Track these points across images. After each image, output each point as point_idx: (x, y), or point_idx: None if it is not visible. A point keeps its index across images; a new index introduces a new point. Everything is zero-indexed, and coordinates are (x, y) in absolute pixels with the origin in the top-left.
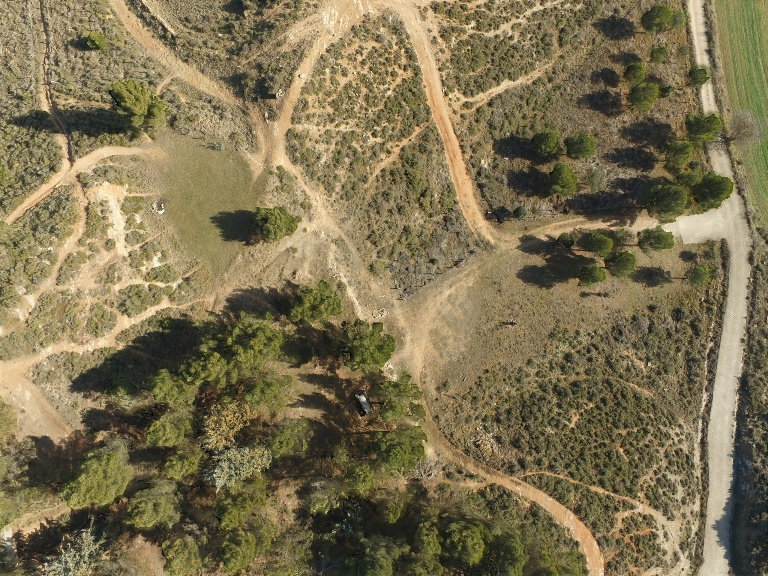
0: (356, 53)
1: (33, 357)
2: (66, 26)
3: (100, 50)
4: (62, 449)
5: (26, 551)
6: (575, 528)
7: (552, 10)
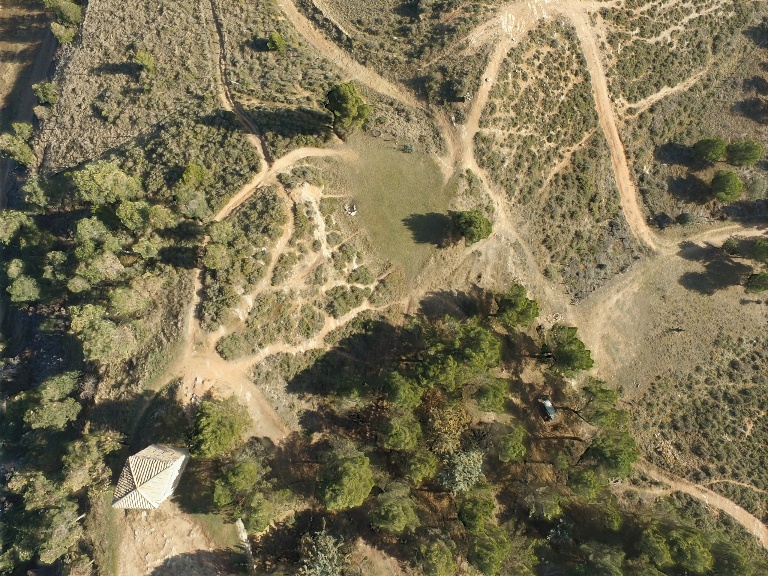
0: (534, 58)
1: (252, 357)
2: (240, 27)
3: (277, 51)
4: (282, 450)
5: (260, 553)
6: (764, 537)
7: (707, 17)
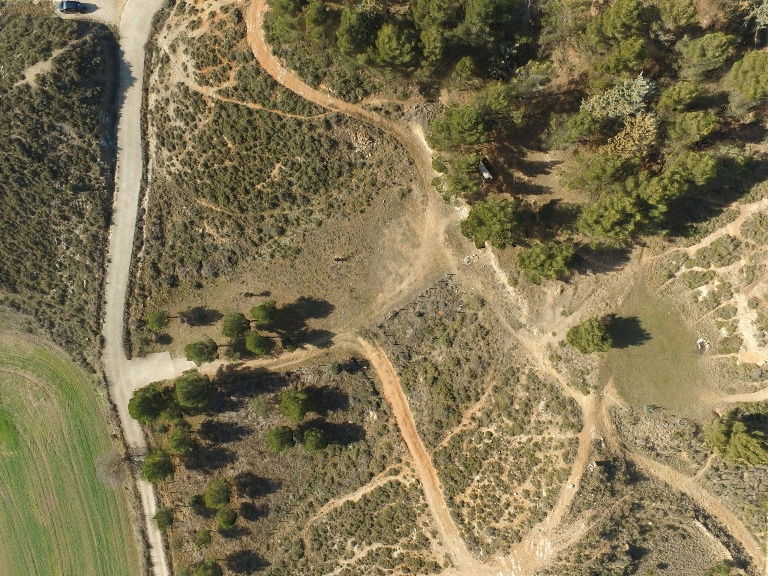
0: (515, 515)
1: None
2: None
3: None
4: None
5: None
6: (276, 68)
7: (313, 575)
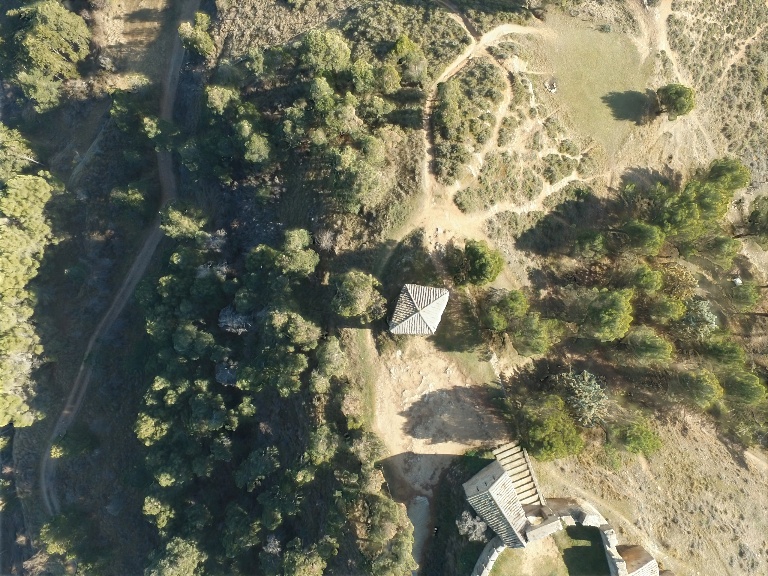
0: None
1: (484, 213)
2: None
3: None
4: None
5: (510, 392)
6: None
7: None
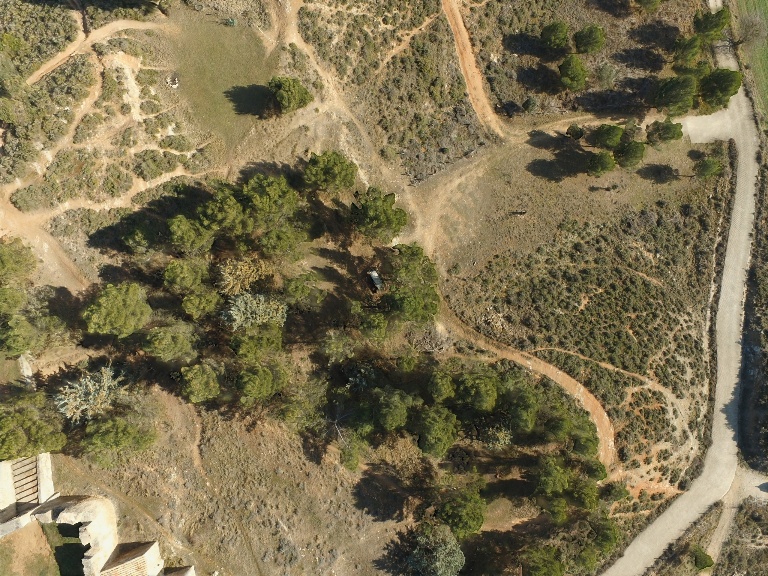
0: None
1: (51, 211)
2: None
3: None
4: (80, 301)
5: None
6: (585, 400)
7: None
